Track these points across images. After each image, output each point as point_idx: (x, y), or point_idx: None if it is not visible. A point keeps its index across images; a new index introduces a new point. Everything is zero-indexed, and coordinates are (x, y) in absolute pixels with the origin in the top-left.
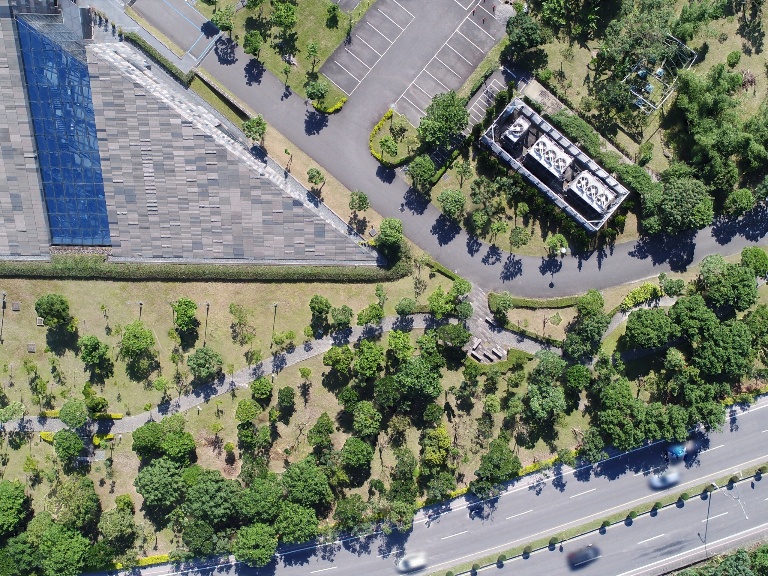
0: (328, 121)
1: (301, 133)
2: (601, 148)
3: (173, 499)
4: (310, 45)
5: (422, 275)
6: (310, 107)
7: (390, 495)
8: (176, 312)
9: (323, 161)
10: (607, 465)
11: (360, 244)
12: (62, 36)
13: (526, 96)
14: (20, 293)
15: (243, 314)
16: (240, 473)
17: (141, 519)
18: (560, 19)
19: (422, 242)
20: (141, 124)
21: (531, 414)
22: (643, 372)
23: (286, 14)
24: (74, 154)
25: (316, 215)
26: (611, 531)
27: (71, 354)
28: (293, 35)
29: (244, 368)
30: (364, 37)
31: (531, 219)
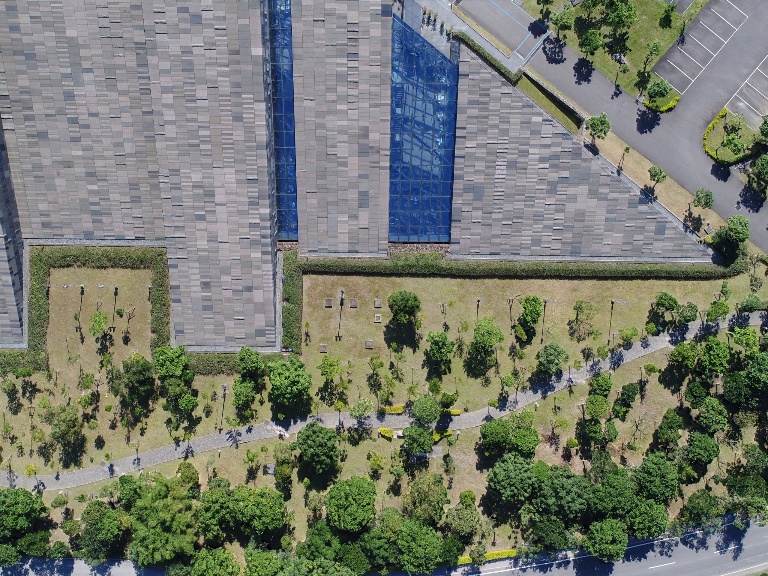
0: (660, 120)
1: (633, 131)
2: None
3: (527, 495)
4: (651, 44)
5: (757, 272)
6: (641, 106)
7: (743, 491)
8: (513, 309)
9: (656, 159)
10: None
11: (697, 241)
12: None
13: None
14: (358, 290)
15: (592, 311)
16: (592, 469)
17: None
18: None
19: (758, 239)
20: (502, 122)
21: None
22: None
23: (628, 13)
24: (403, 152)
25: (660, 213)
26: None
27: (409, 351)
28: (624, 34)
29: (581, 365)
30: (697, 36)
31: None
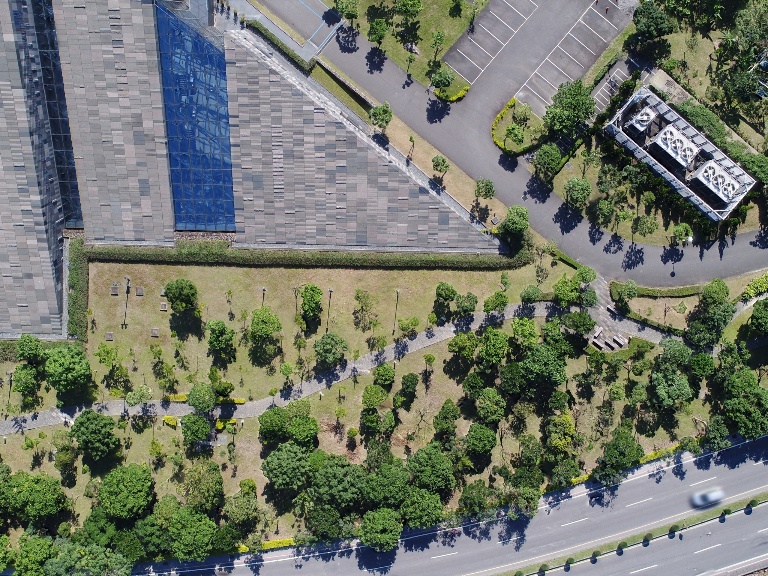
0: (450, 109)
1: (423, 121)
2: (727, 138)
3: (300, 483)
4: (436, 33)
5: (544, 263)
6: (432, 95)
7: (516, 481)
8: (299, 298)
9: (445, 149)
10: (727, 454)
11: (483, 232)
12: (194, 22)
13: (652, 85)
14: (144, 278)
15: (370, 300)
16: (367, 458)
17: (263, 503)
18: (685, 9)
19: (544, 230)
20: (274, 110)
21: (657, 402)
22: (764, 361)
23: (413, 2)
24: (195, 141)
25: (441, 202)
26: (731, 519)
27: (194, 339)
28: (415, 24)
29: (366, 354)
30: (487, 26)
31: (653, 208)
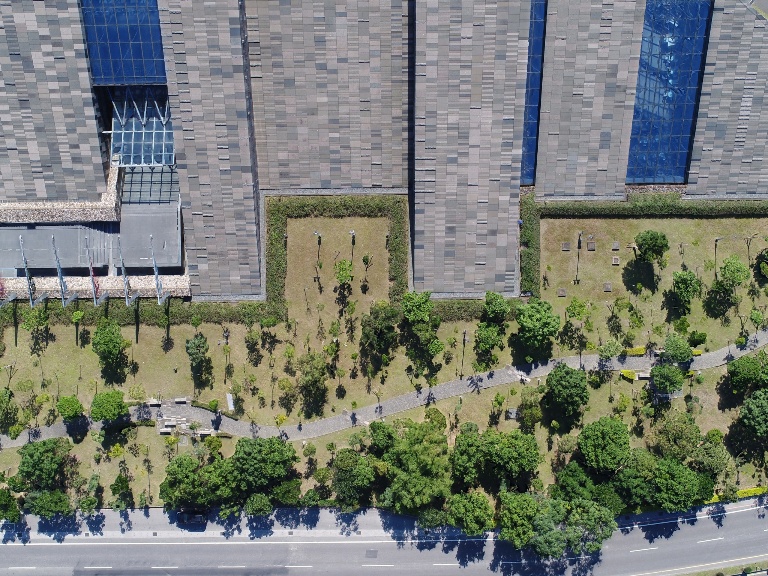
0: None
1: None
2: None
3: None
4: None
5: None
6: None
7: None
8: (751, 248)
9: None
10: None
11: None
12: None
13: None
14: (595, 233)
15: None
16: None
17: None
18: None
19: None
20: (752, 57)
21: None
22: None
23: None
24: None
25: None
26: None
27: (647, 292)
28: None
29: None
30: None
31: None
